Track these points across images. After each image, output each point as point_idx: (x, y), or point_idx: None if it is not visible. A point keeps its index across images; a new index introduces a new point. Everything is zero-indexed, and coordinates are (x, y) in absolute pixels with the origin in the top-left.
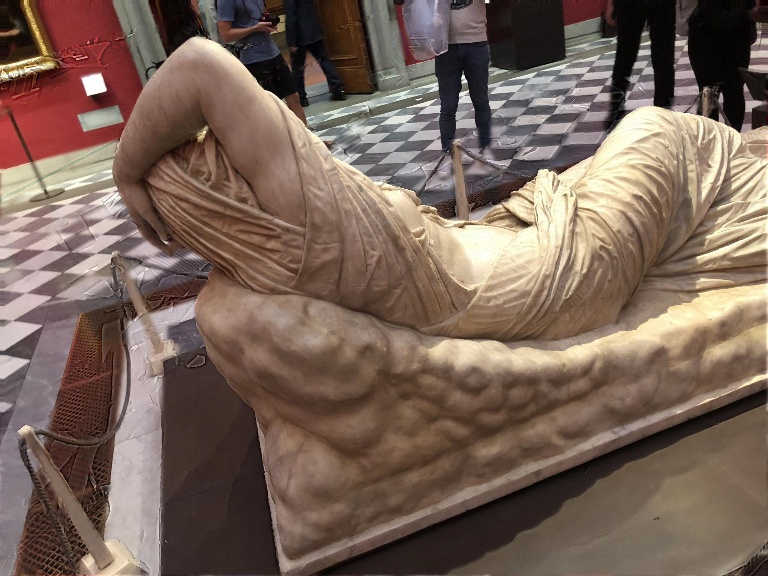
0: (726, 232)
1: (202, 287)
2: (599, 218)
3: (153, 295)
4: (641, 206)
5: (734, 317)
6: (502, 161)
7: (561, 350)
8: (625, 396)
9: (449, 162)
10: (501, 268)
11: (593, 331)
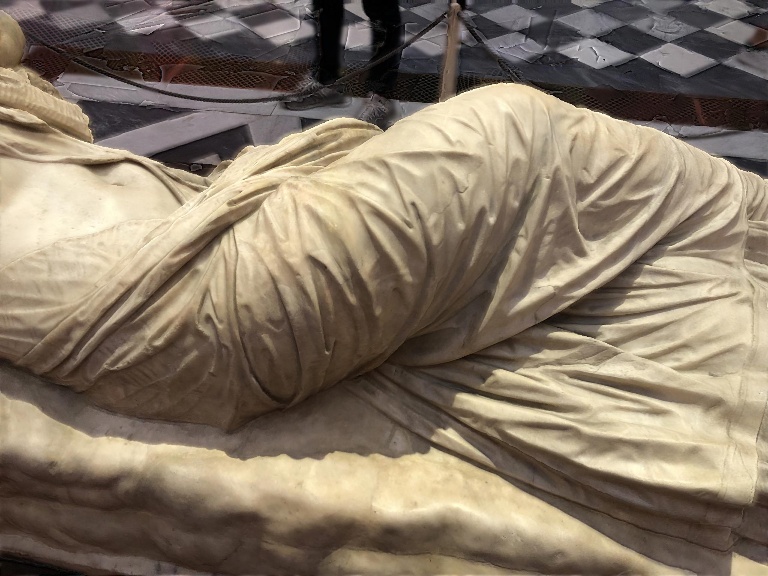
0: (528, 383)
1: (79, 74)
2: (231, 267)
3: (25, 61)
4: (318, 282)
5: (422, 528)
6: (625, 53)
7: (90, 434)
8: (173, 540)
9: (444, 32)
10: (17, 274)
11: (181, 426)
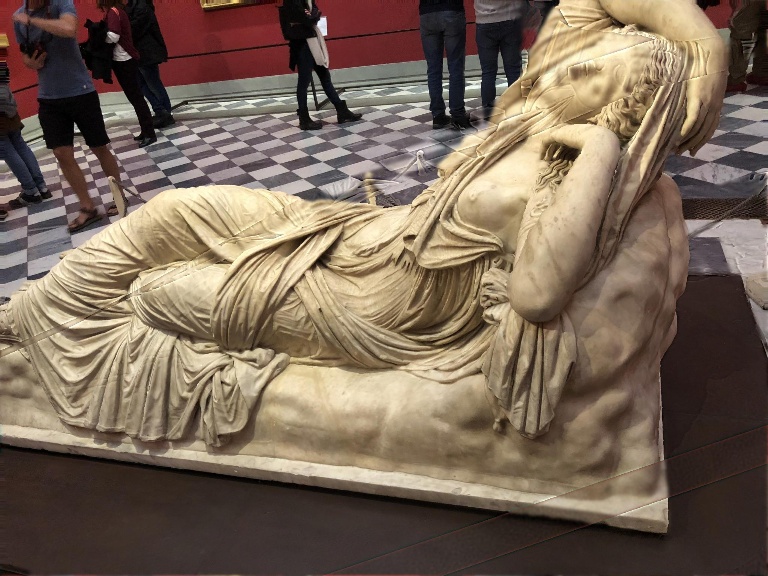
0: None
1: None
2: None
3: None
4: None
5: None
6: None
7: None
8: None
9: None
10: None
11: None
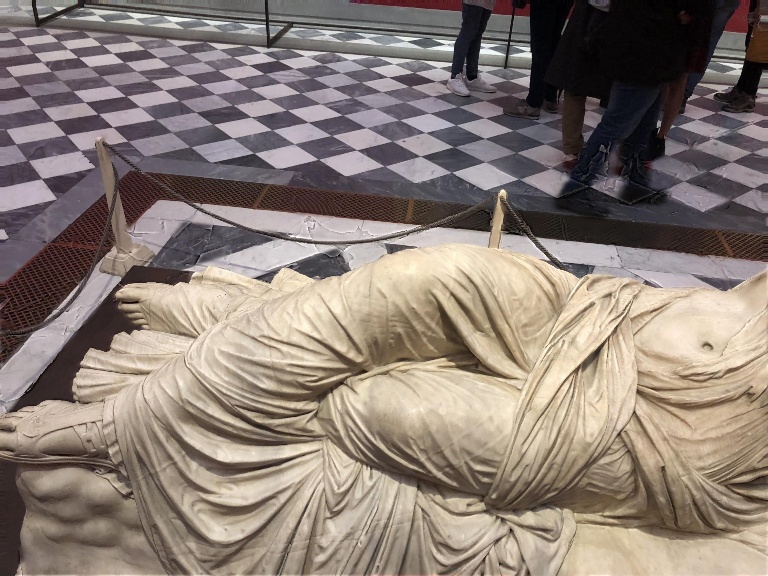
0: None
1: None
2: None
3: None
4: None
5: None
6: None
7: None
8: None
9: None
10: None
11: None
